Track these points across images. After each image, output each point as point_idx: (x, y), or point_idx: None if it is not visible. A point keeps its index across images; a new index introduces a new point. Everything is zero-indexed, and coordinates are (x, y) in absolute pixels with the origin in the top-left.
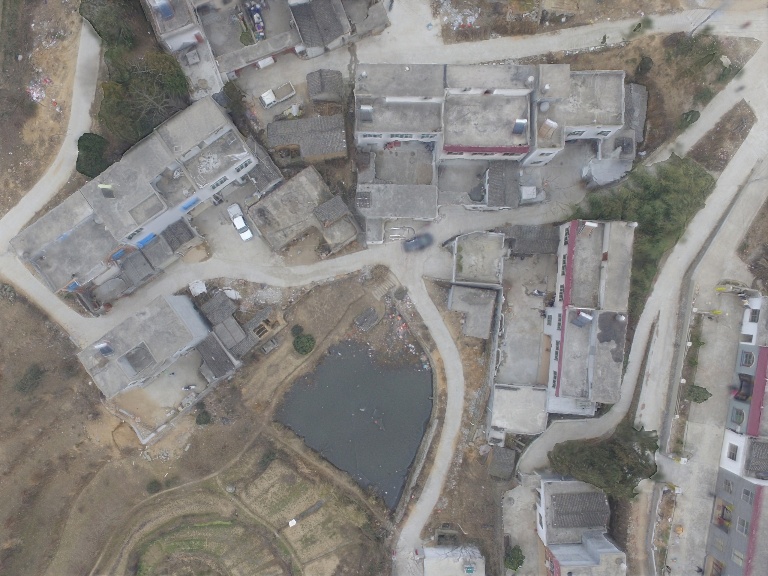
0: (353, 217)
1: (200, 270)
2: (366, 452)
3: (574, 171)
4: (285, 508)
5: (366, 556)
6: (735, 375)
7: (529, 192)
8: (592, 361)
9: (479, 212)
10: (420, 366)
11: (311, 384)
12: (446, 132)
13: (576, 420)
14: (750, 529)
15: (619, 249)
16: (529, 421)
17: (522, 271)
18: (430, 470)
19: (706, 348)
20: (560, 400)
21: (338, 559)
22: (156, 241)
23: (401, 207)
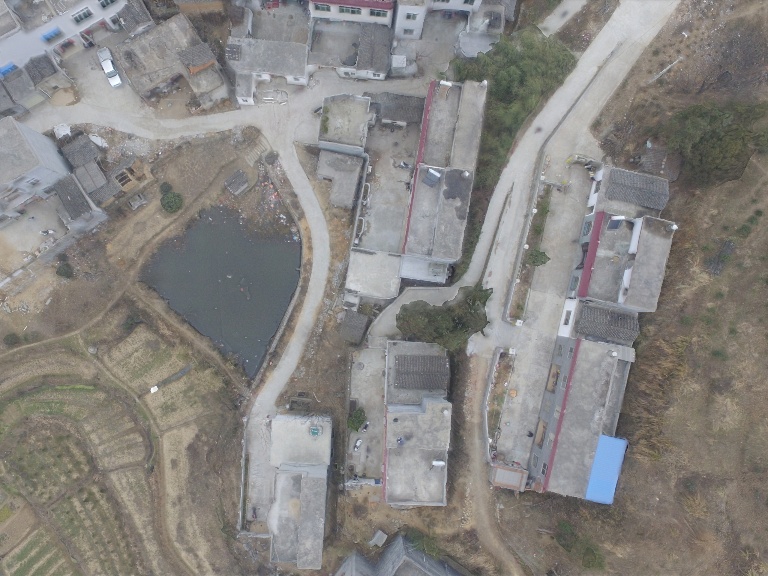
0: (223, 70)
1: (67, 114)
2: (232, 322)
3: (448, 48)
4: (148, 374)
5: (225, 426)
6: (578, 247)
7: (399, 61)
8: (437, 218)
9: (353, 81)
10: (290, 237)
11: (180, 247)
12: None
13: (428, 288)
14: (568, 381)
15: (470, 109)
16: (383, 286)
17: (391, 143)
18: (290, 338)
19: (553, 219)
20: (413, 266)
21: (197, 428)
22: (19, 75)
23: (270, 63)
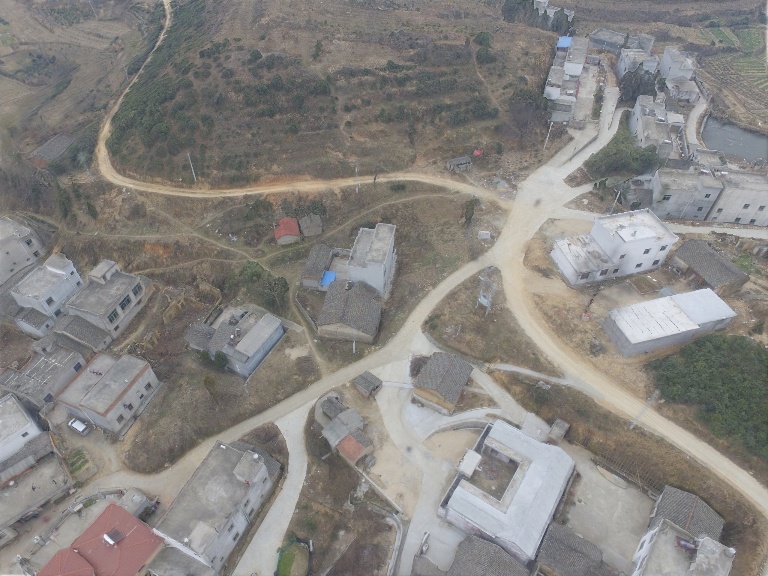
0: None
1: None
2: None
3: None
4: None
5: None
6: None
7: None
8: None
9: None
10: None
11: None
12: (766, 180)
13: None
14: None
15: None
16: None
17: None
18: None
19: None
20: None
21: None
22: None
23: None
